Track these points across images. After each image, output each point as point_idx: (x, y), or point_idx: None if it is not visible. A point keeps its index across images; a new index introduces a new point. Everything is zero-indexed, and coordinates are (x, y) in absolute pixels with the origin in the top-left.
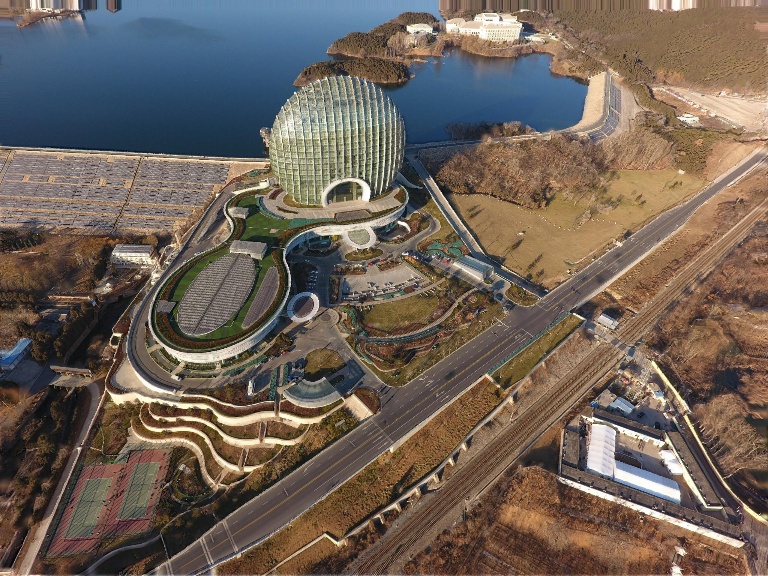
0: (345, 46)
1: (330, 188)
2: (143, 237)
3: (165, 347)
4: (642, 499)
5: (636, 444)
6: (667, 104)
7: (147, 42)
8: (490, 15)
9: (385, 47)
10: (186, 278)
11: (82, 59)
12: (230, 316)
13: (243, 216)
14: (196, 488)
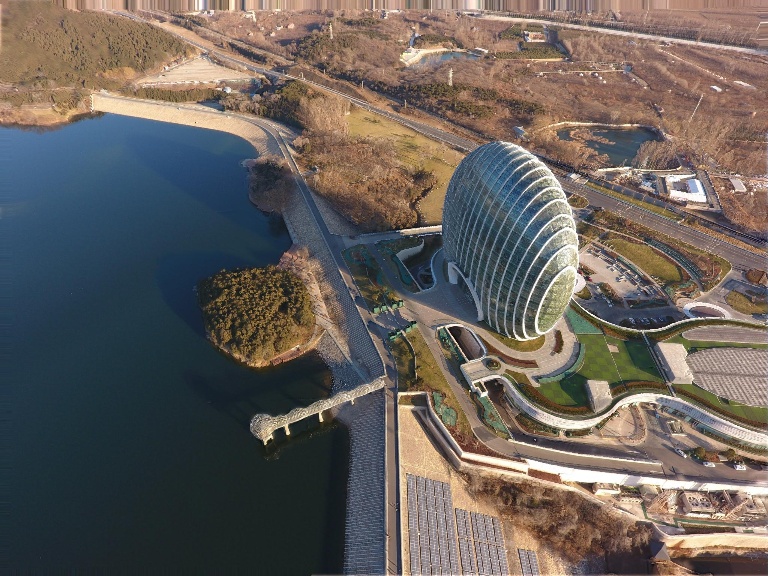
0: None
1: None
2: None
3: None
4: (711, 189)
5: (669, 187)
6: (189, 90)
7: None
8: None
9: None
10: None
11: None
12: None
13: None
14: None
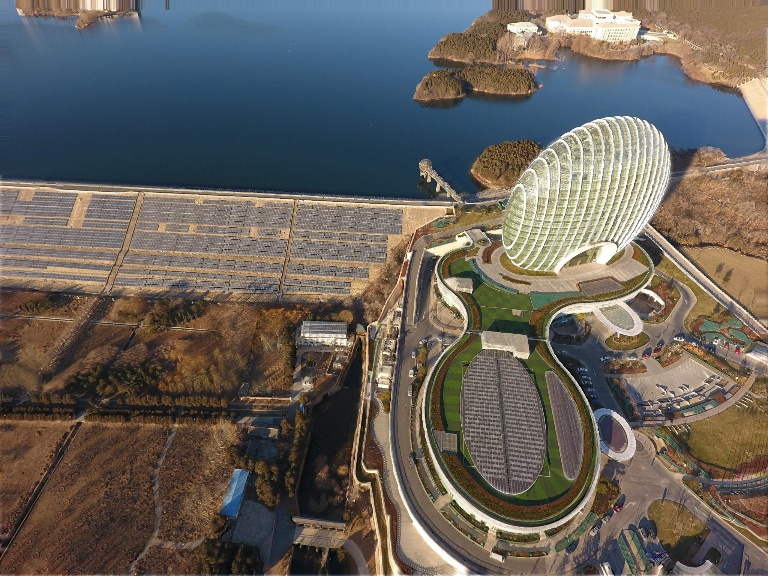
0: (449, 49)
1: (576, 254)
2: (322, 306)
3: (484, 516)
4: None
5: None
6: None
7: (244, 50)
8: (601, 12)
9: (496, 51)
10: (448, 391)
11: (179, 72)
12: (541, 458)
13: (470, 290)
14: None
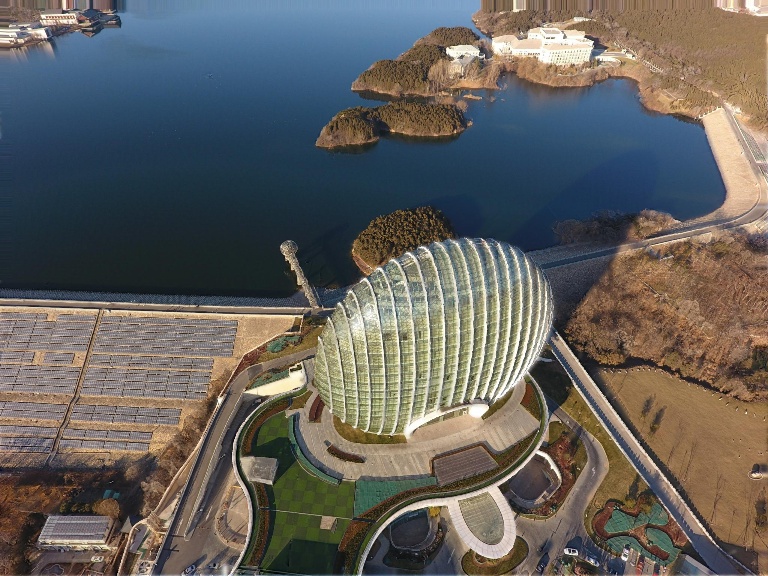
0: (374, 80)
1: (424, 422)
2: (98, 478)
3: None
4: None
5: None
6: None
7: None
8: (550, 31)
9: (426, 81)
10: None
11: (32, 123)
12: None
13: (268, 482)
14: None
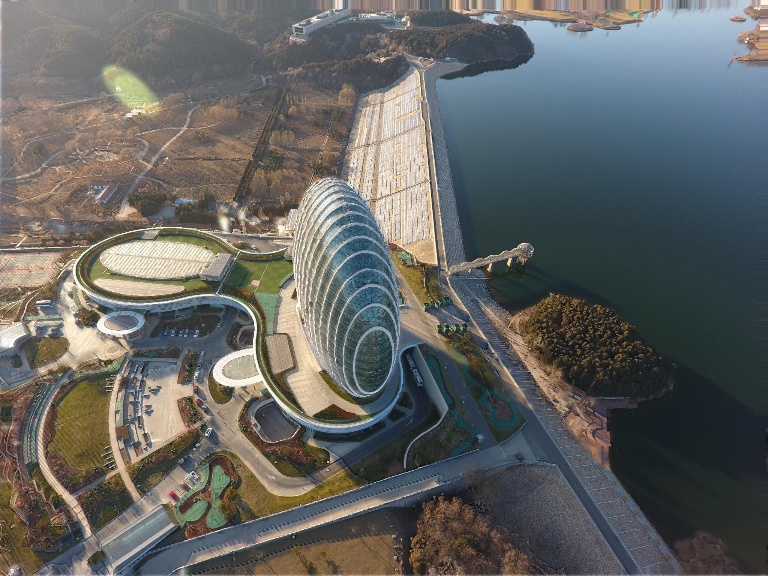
0: None
1: None
2: None
3: None
4: None
5: None
6: None
7: (719, 113)
8: None
9: None
10: (187, 238)
11: (628, 97)
12: (116, 270)
13: None
14: (4, 303)
